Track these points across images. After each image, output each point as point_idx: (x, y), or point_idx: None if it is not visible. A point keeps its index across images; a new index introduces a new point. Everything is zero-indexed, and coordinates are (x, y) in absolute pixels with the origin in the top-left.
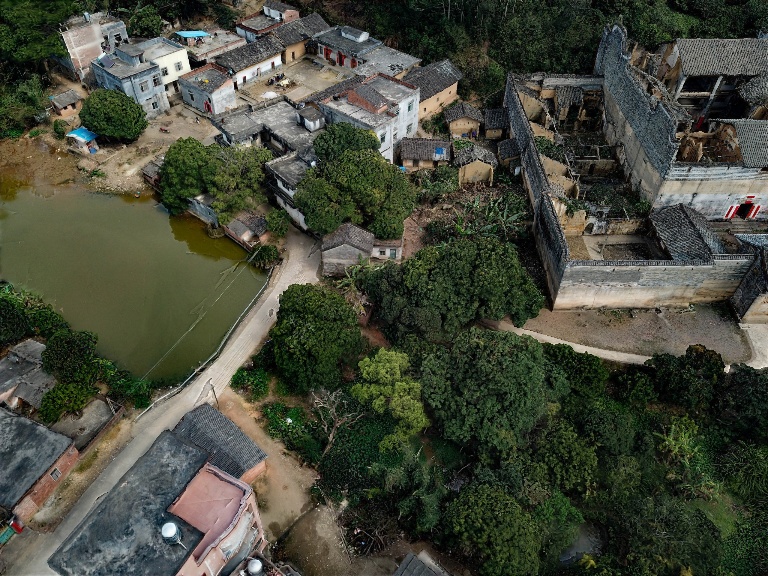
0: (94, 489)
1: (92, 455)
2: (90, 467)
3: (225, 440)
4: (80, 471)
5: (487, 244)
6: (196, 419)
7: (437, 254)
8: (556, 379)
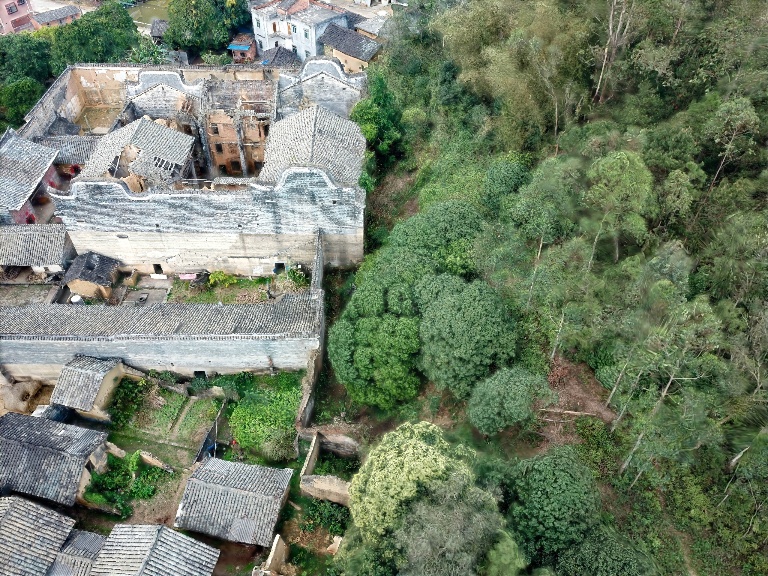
0: (64, 5)
1: (80, 2)
2: (76, 4)
3: (53, 13)
4: (74, 2)
5: (82, 23)
6: (69, 7)
7: (98, 21)
8: (7, 78)
